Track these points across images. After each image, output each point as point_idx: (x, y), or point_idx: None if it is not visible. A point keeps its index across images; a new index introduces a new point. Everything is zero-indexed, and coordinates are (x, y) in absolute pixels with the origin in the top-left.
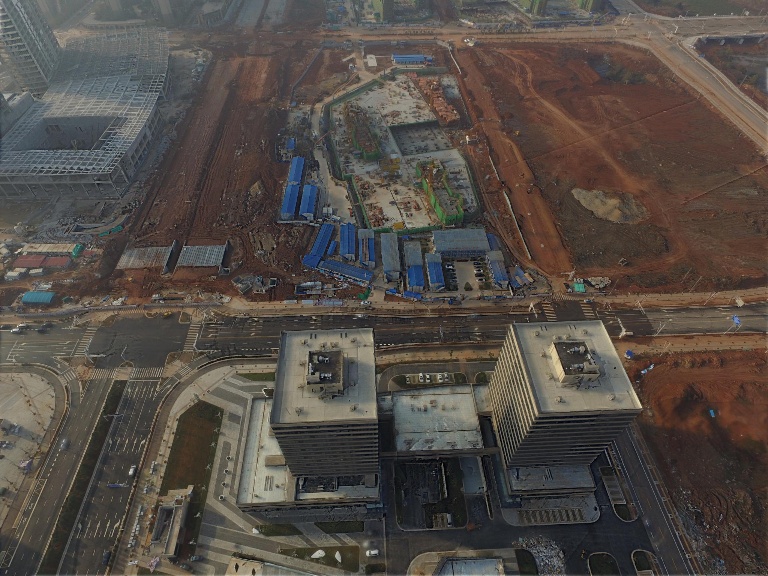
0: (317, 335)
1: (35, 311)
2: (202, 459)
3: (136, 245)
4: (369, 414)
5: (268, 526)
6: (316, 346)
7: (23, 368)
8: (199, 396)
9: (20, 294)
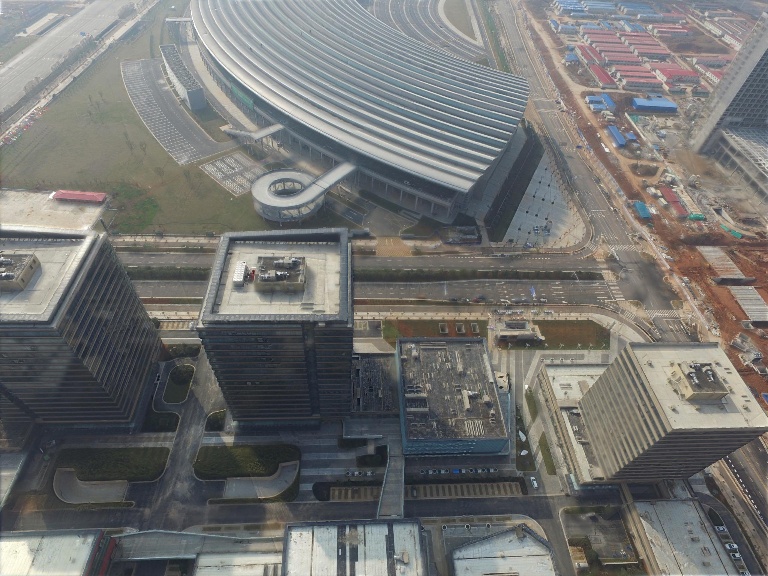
0: (732, 374)
1: (631, 213)
2: (565, 341)
3: (729, 252)
4: (674, 423)
5: (532, 395)
6: (719, 374)
7: (587, 222)
8: (613, 329)
9: (639, 200)
